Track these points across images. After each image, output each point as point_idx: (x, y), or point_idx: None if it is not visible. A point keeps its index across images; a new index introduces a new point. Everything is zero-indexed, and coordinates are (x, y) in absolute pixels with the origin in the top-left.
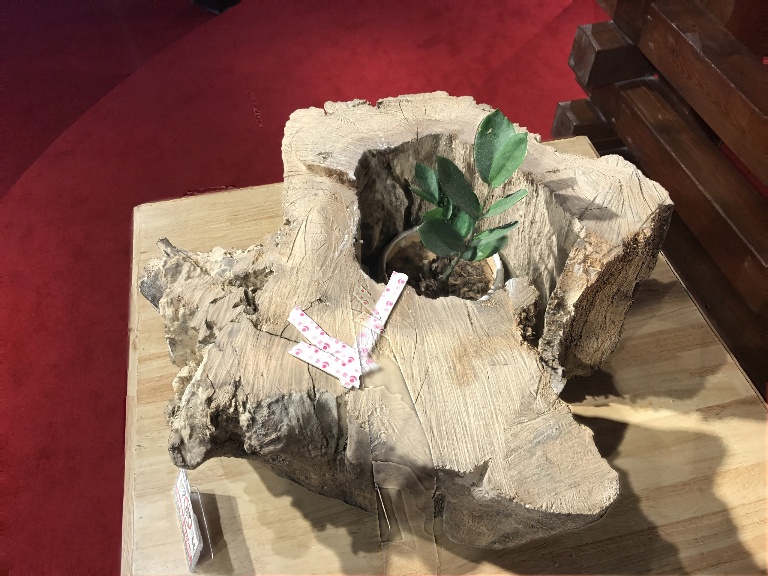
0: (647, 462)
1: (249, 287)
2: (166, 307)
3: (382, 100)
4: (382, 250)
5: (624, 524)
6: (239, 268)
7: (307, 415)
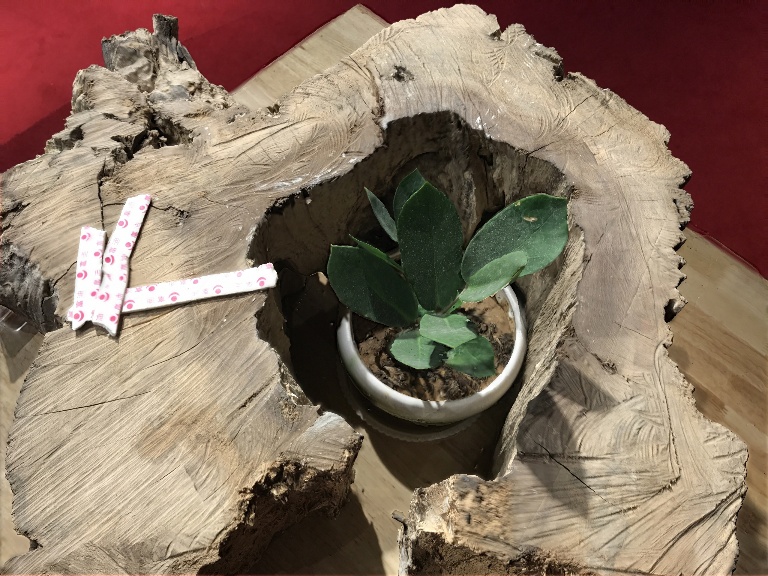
0: None
1: None
2: (79, 81)
3: (578, 75)
4: None
5: None
6: (170, 107)
7: (35, 300)
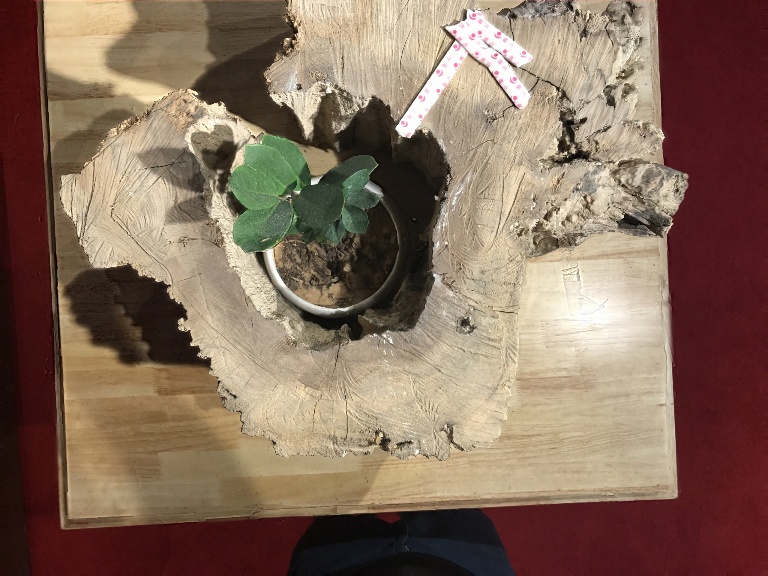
0: (185, 55)
1: None
2: (657, 132)
3: (369, 448)
4: (397, 280)
5: (229, 5)
6: (579, 170)
7: None
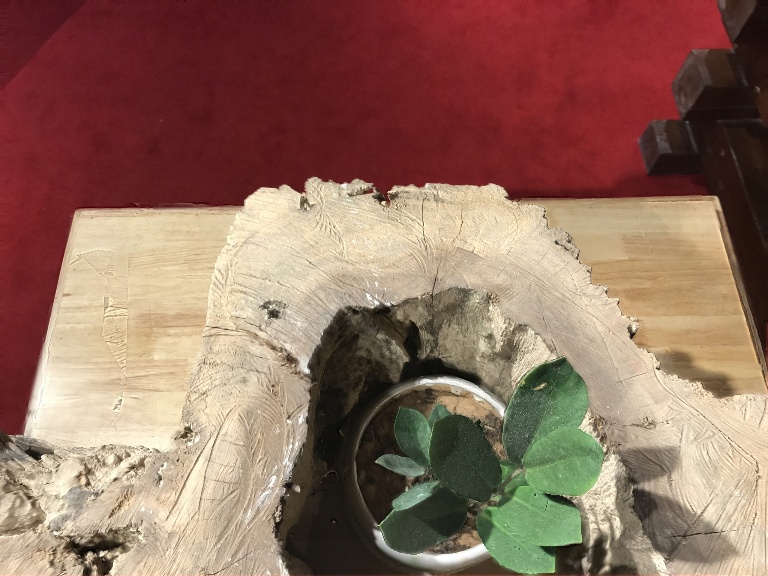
0: None
1: (101, 550)
2: None
3: (397, 190)
4: (360, 416)
5: None
6: (87, 521)
7: None
